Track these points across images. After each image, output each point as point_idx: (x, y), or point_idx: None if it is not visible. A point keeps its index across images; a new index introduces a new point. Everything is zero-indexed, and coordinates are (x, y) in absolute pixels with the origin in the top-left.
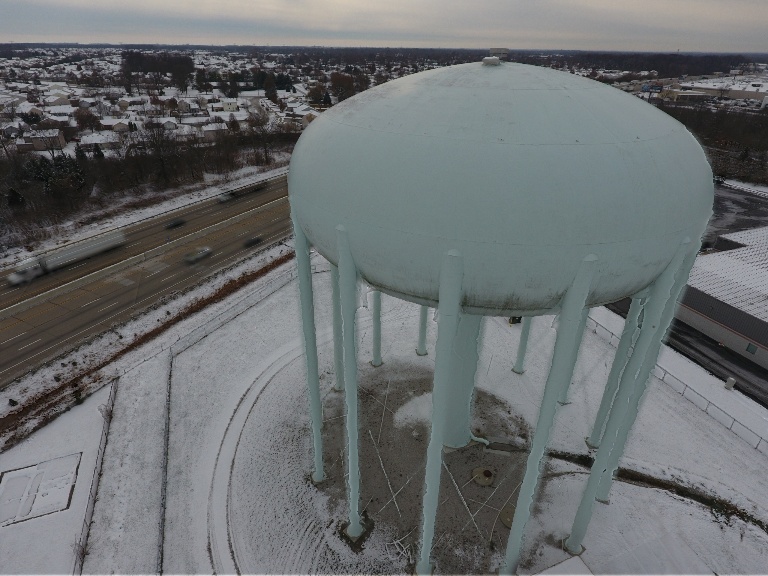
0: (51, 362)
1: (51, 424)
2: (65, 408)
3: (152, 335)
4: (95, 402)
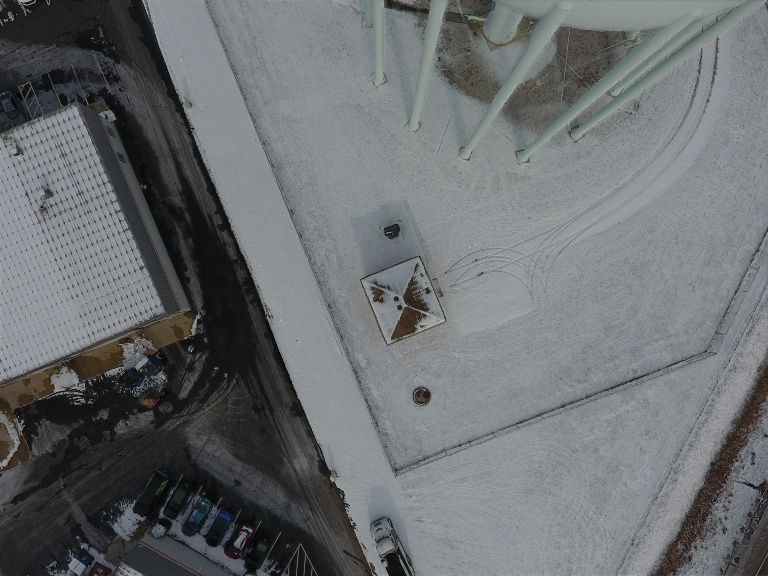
0: None
1: None
2: None
3: None
4: None
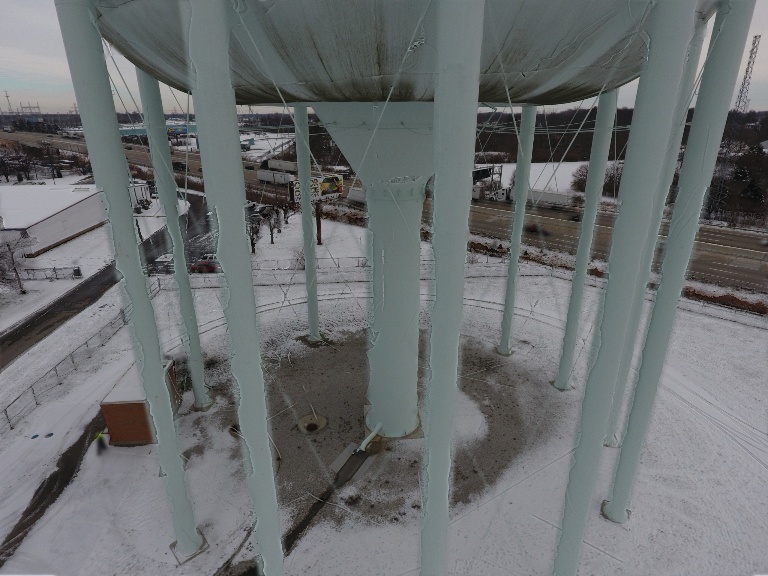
0: (543, 247)
1: None
2: (485, 252)
3: (598, 274)
4: (492, 259)
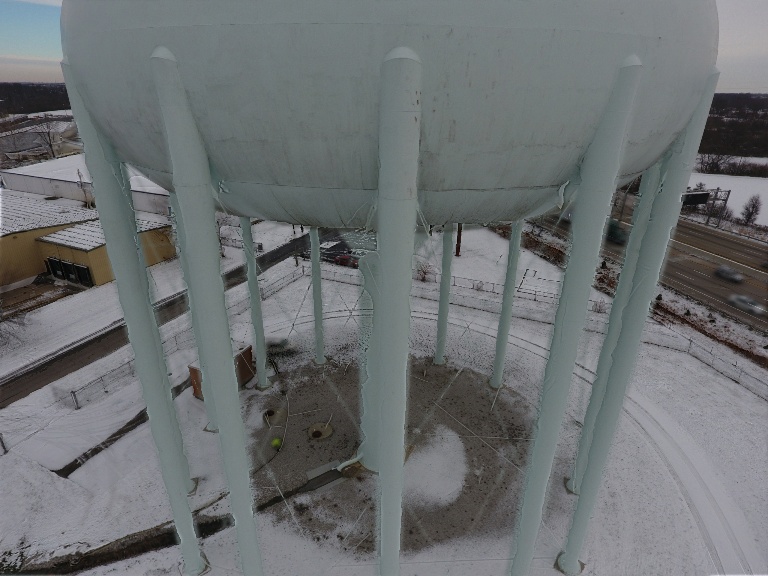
0: (715, 310)
1: (610, 298)
2: None
3: None
4: None
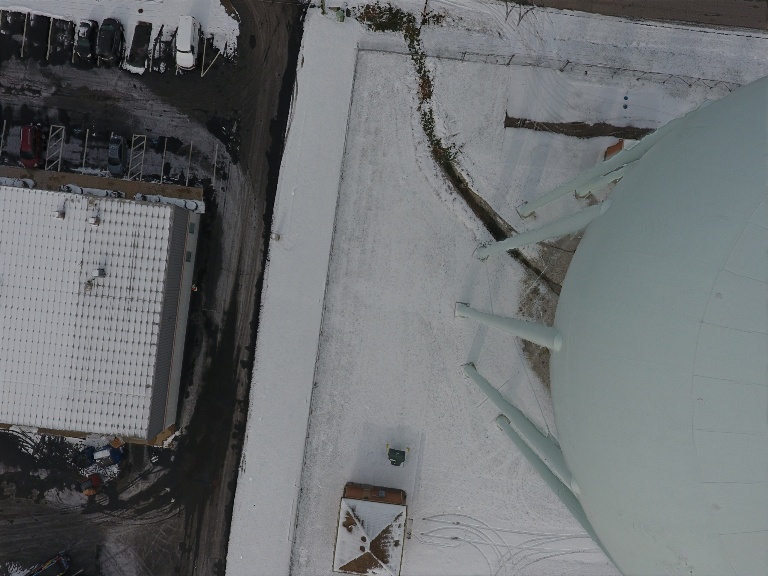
0: None
1: None
2: None
3: None
4: None
